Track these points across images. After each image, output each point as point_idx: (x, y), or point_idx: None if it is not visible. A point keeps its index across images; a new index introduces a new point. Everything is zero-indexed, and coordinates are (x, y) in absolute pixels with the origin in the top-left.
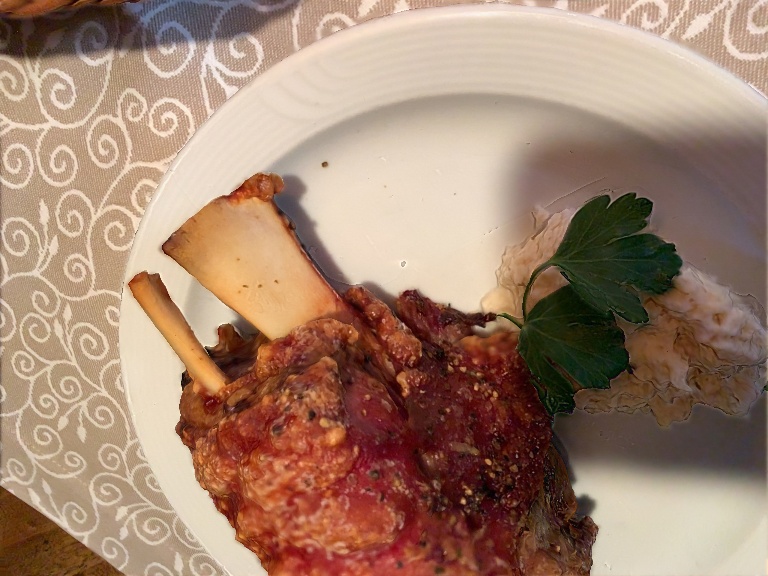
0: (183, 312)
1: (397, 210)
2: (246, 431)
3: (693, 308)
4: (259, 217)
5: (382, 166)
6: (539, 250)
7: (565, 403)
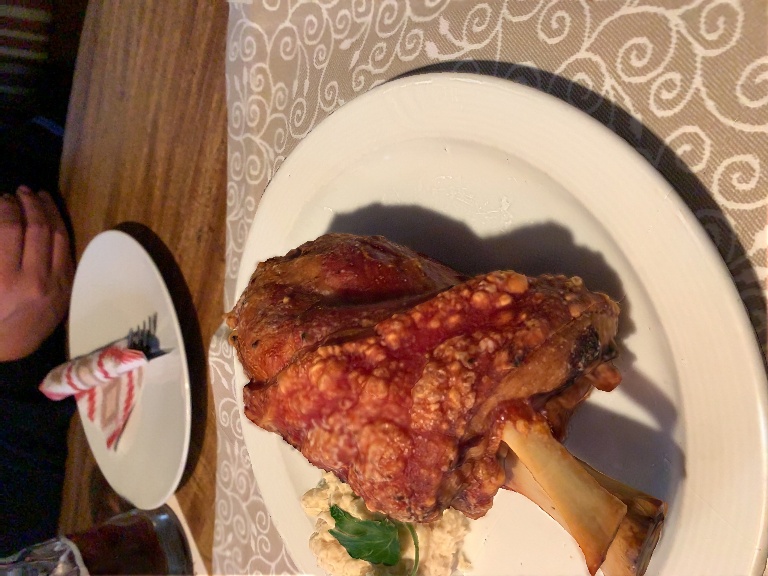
0: (677, 366)
1: (553, 537)
2: (422, 475)
3: (344, 569)
4: (600, 567)
5: (583, 574)
6: (438, 557)
7: (335, 515)
